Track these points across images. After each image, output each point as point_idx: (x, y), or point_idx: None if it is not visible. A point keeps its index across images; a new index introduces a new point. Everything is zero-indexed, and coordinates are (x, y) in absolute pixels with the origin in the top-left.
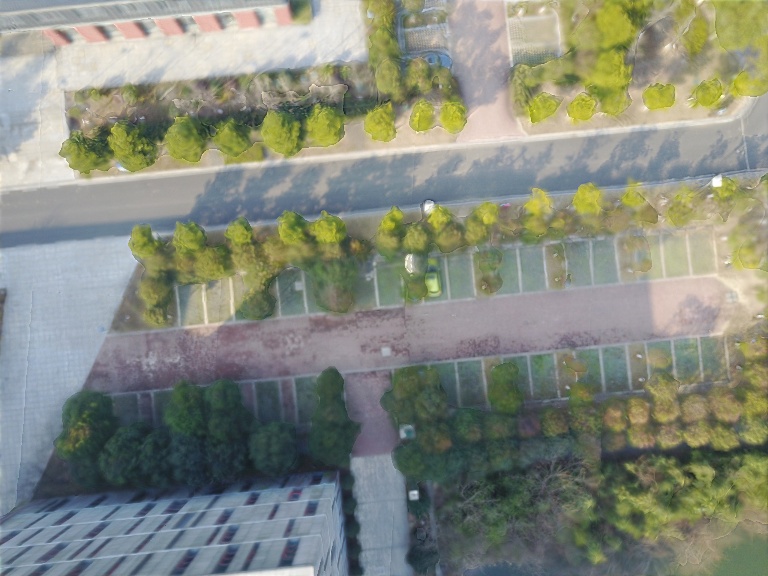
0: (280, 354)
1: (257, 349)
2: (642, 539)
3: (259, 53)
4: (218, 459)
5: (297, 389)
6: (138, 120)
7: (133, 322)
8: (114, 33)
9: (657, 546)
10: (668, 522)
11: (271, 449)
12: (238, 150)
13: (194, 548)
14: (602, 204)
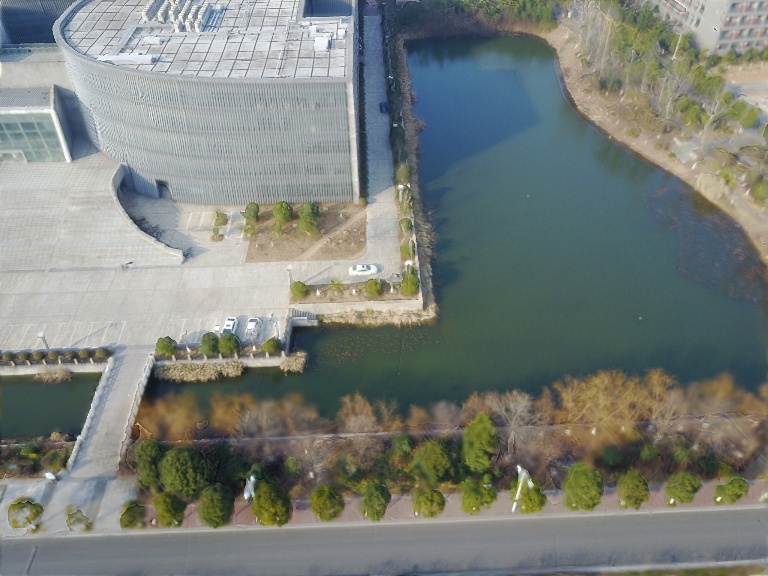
0: None
1: None
2: None
3: None
4: None
5: None
6: None
7: None
8: None
9: None
10: (470, 3)
11: None
12: None
13: None
14: None
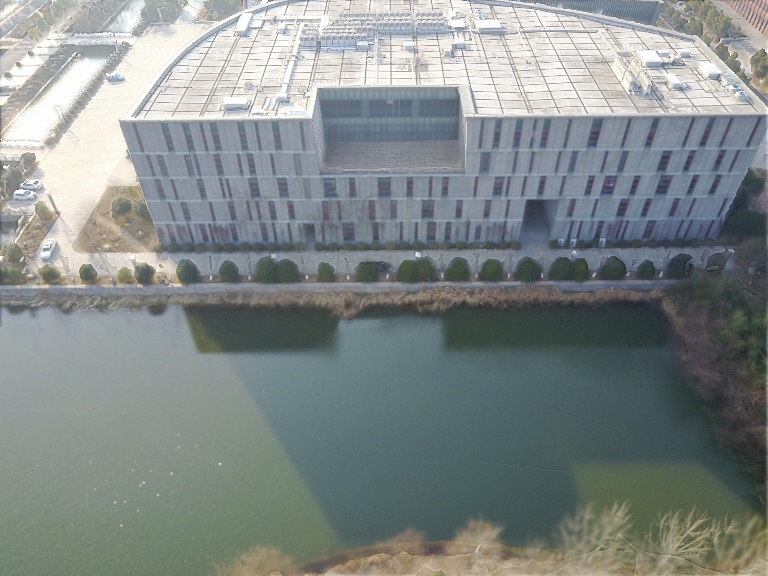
0: None
1: None
2: (760, 351)
3: None
4: None
5: None
6: None
7: (765, 175)
8: None
9: (747, 374)
10: None
11: None
12: None
13: None
14: None
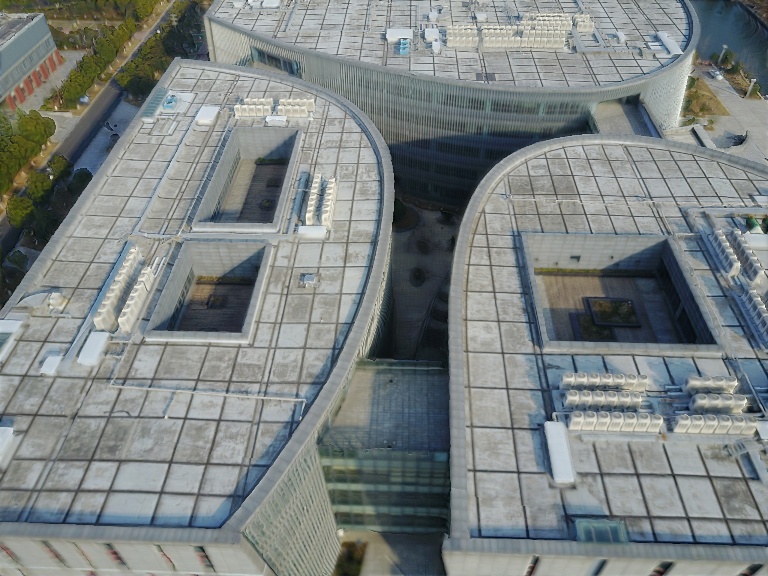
0: None
1: None
2: None
3: (67, 70)
4: None
5: None
6: None
7: None
8: (25, 95)
9: None
10: None
11: None
12: (104, 61)
13: None
14: (186, 18)
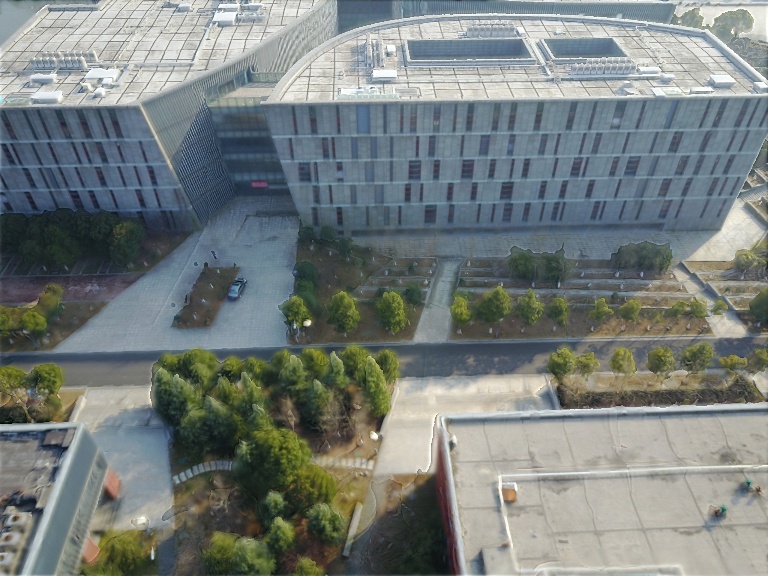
0: (0, 287)
1: (13, 290)
2: None
3: None
4: (40, 216)
5: (2, 271)
6: (6, 420)
7: None
8: None
9: None
10: None
11: (5, 217)
12: None
13: (16, 141)
14: None
